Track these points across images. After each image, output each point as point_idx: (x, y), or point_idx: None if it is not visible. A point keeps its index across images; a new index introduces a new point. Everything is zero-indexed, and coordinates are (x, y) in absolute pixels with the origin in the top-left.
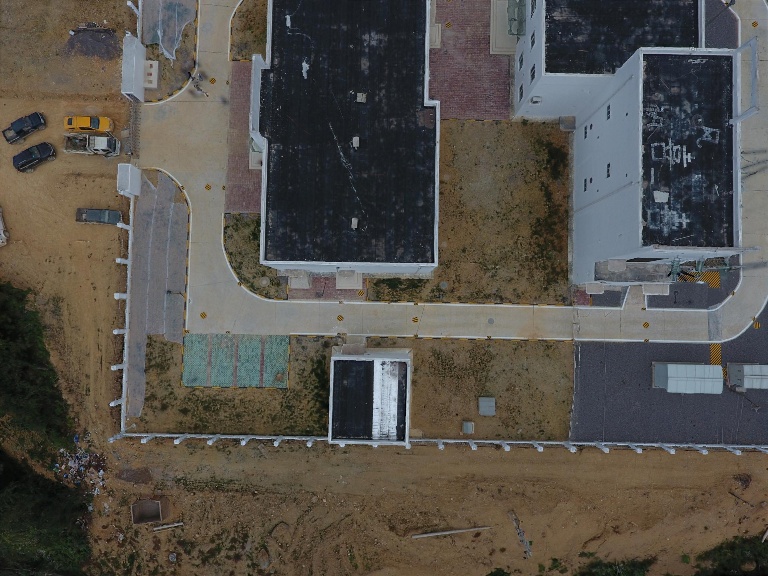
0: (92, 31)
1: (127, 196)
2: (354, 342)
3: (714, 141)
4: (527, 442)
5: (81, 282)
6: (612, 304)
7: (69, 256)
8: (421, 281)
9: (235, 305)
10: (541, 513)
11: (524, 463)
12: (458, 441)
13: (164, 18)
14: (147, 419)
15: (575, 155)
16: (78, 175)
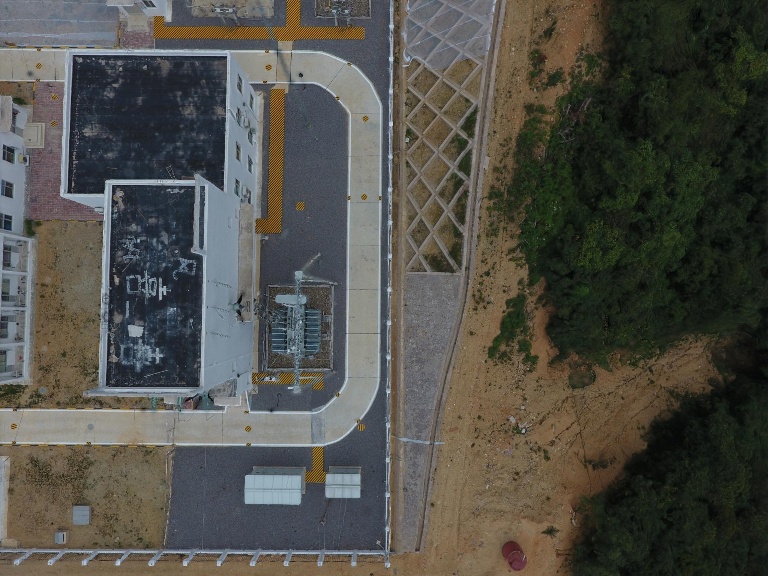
0: None
1: None
2: None
3: (190, 273)
4: (121, 551)
5: None
6: (214, 407)
7: None
8: (20, 387)
9: None
10: None
11: (123, 571)
12: (50, 551)
13: None
14: None
15: None
16: None
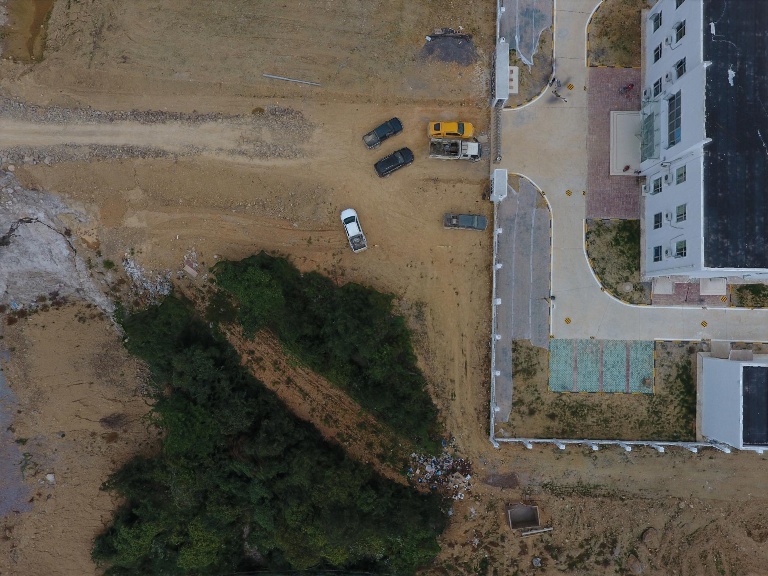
0: (451, 37)
1: None
2: (719, 348)
3: None
4: None
5: (444, 287)
6: None
7: (431, 261)
8: None
9: (599, 310)
10: None
11: None
12: None
13: (521, 24)
14: (515, 424)
15: None
16: (436, 180)
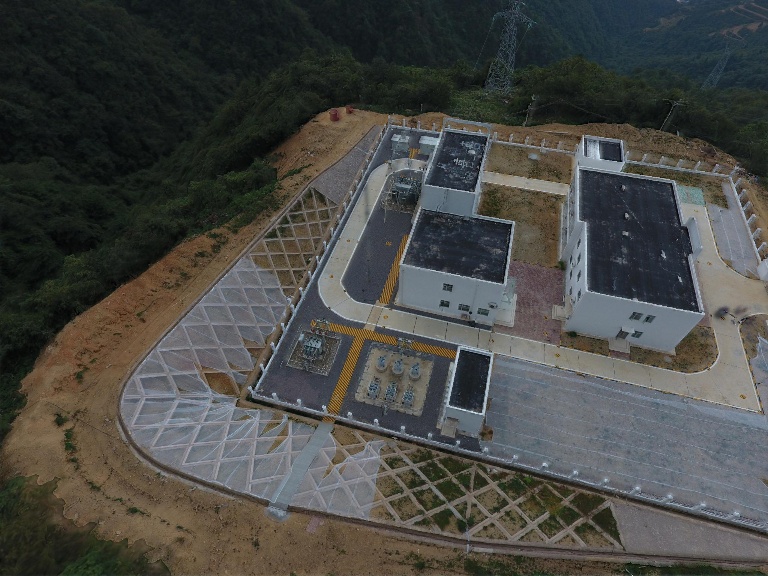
0: None
1: None
2: None
3: (441, 163)
4: (513, 144)
5: None
6: None
7: None
8: None
9: None
10: (508, 126)
11: None
12: (548, 149)
13: None
14: (718, 180)
15: None
16: None
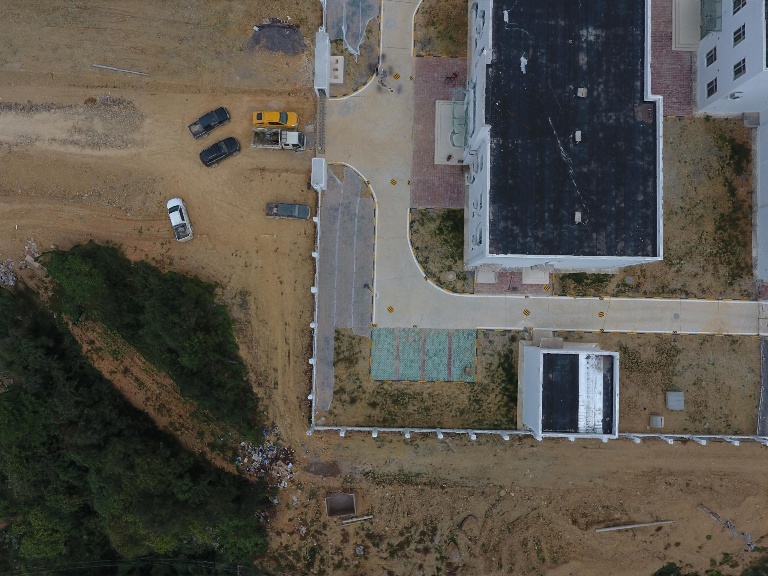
0: (277, 27)
1: (318, 190)
2: (541, 336)
3: None
4: (716, 436)
5: (268, 276)
6: None
7: (255, 250)
8: (607, 276)
9: (422, 299)
10: (729, 507)
11: (710, 457)
12: (647, 435)
13: (348, 14)
14: (336, 412)
15: (760, 151)
16: (263, 170)
